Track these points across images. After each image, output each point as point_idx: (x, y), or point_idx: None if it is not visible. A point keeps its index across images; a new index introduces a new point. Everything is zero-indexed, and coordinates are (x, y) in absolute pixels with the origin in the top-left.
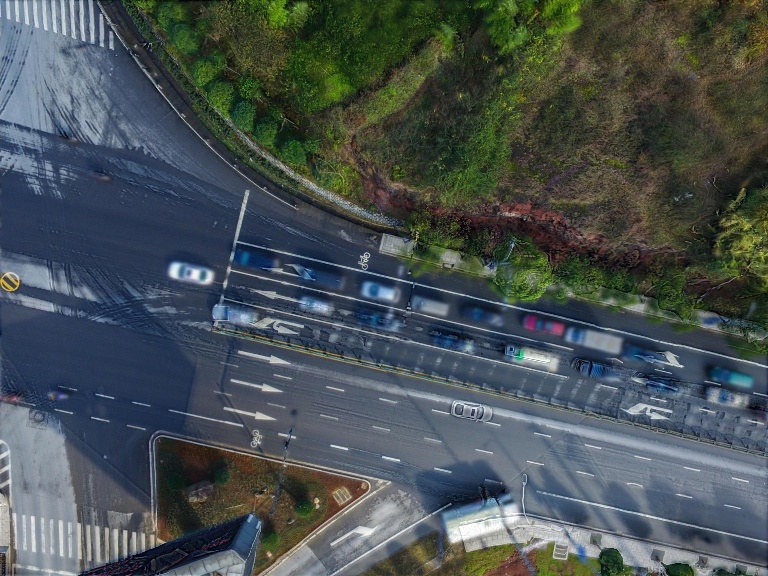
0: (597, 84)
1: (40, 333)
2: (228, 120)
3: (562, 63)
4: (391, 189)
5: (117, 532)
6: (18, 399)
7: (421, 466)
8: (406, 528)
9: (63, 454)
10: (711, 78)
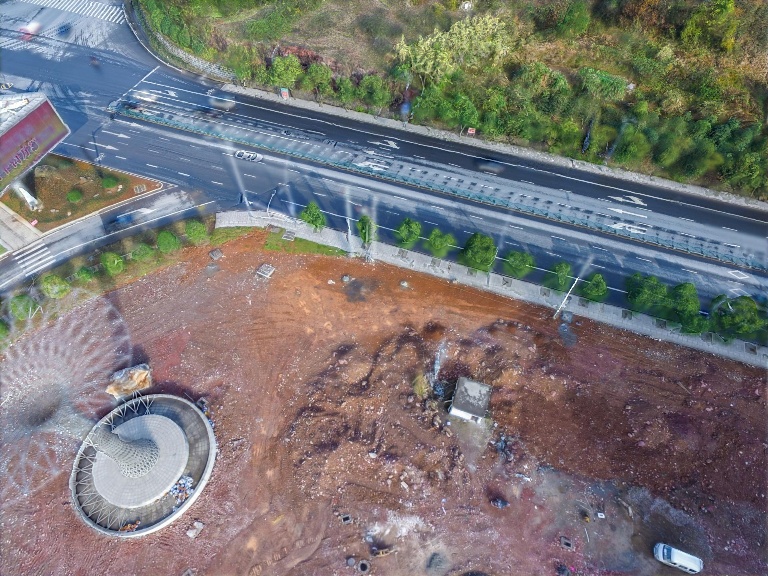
0: (338, 12)
1: None
2: (162, 39)
3: (324, 7)
4: None
5: None
6: None
7: (203, 180)
8: (177, 212)
9: None
10: (394, 10)
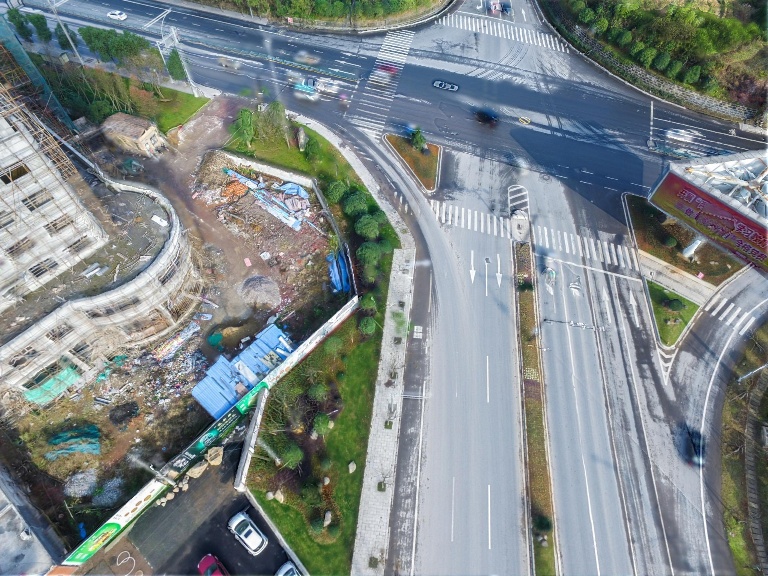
0: None
1: (544, 141)
2: (641, 72)
3: None
4: (752, 89)
5: (606, 244)
6: (532, 168)
7: None
8: None
9: (563, 197)
10: None
